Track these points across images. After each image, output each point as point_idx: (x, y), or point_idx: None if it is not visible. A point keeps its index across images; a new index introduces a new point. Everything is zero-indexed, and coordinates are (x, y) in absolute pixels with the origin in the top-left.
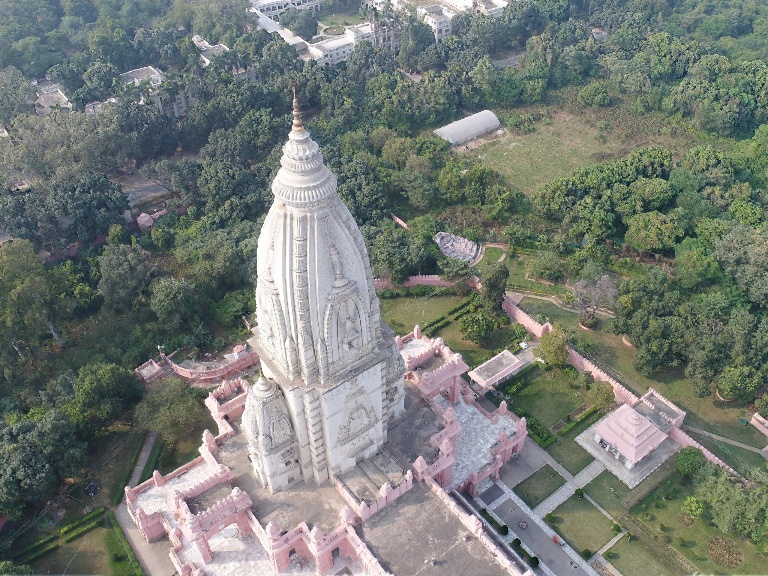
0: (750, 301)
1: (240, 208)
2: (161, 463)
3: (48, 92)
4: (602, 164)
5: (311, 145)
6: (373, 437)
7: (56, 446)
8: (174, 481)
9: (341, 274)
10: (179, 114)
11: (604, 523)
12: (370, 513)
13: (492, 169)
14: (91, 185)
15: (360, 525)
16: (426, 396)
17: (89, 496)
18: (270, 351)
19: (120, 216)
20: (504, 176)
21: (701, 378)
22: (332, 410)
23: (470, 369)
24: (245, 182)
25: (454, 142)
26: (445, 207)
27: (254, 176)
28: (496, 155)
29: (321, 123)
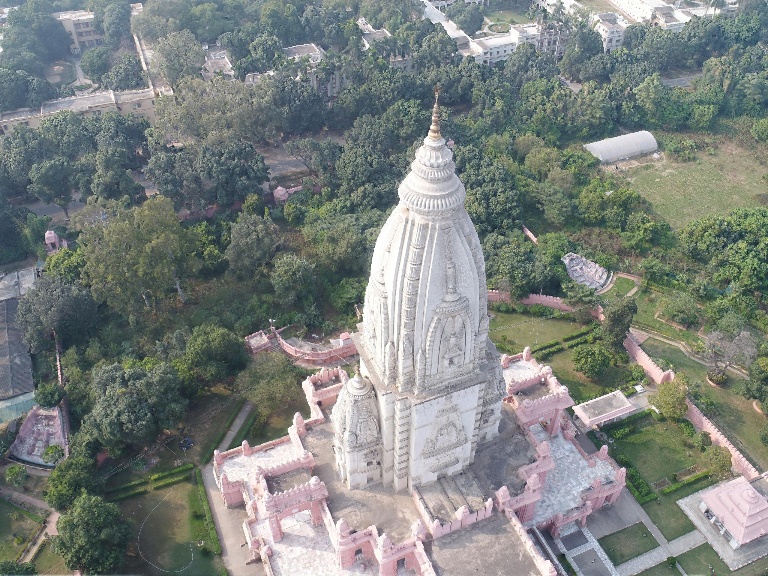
0: None
1: (372, 196)
2: (252, 433)
3: (216, 57)
4: (766, 207)
5: (445, 153)
6: (459, 456)
7: (160, 398)
8: (260, 454)
9: (453, 288)
10: (332, 94)
11: None
12: (442, 532)
13: (640, 194)
14: (237, 153)
15: (430, 542)
16: (523, 424)
17: (182, 450)
18: (370, 350)
19: (259, 186)
20: (652, 204)
21: None
22: (422, 422)
23: (576, 403)
24: (382, 171)
25: (604, 160)
26: (581, 227)
27: (392, 166)
28: (647, 180)
29: (468, 121)
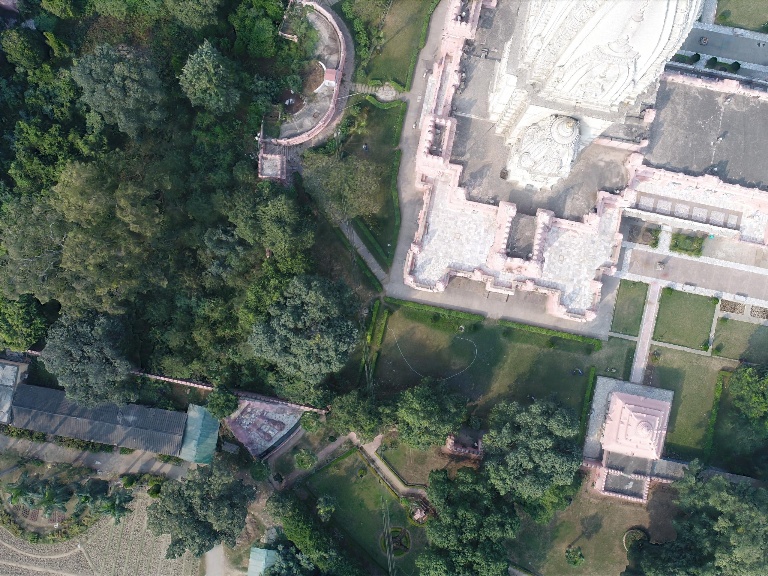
0: None
1: None
2: (378, 232)
3: None
4: None
5: None
6: None
7: (336, 305)
8: (427, 239)
9: None
10: None
11: None
12: None
13: None
14: None
15: None
16: None
17: None
18: (573, 99)
19: None
20: None
21: None
22: None
23: None
24: None
25: None
26: None
27: None
28: None
29: None
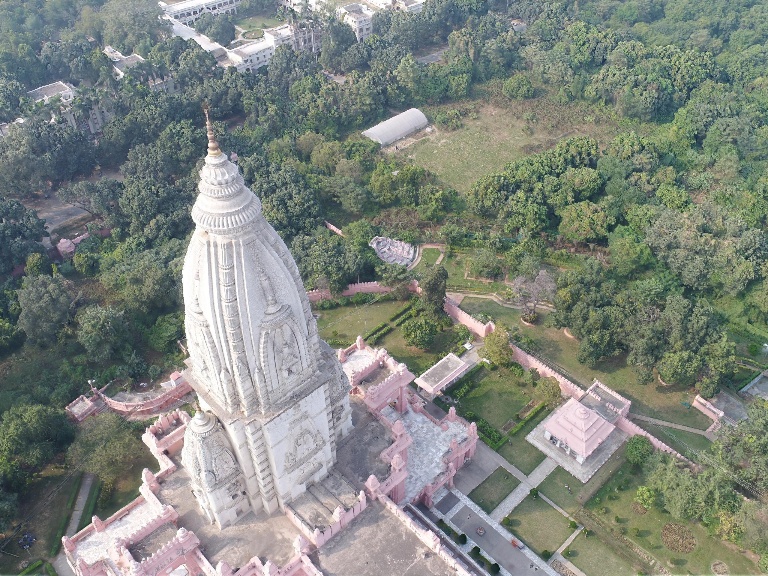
0: (683, 284)
1: (167, 226)
2: (100, 506)
3: None
4: (531, 157)
5: (230, 168)
6: (322, 460)
7: None
8: (115, 525)
9: (273, 300)
10: (95, 130)
11: (560, 521)
12: (325, 539)
13: (423, 168)
14: (3, 213)
15: (315, 553)
16: (373, 410)
17: (24, 549)
18: (205, 384)
19: (38, 243)
20: (436, 174)
21: (643, 366)
22: (276, 439)
23: (416, 376)
24: (170, 198)
25: (383, 143)
26: (379, 210)
27: (179, 191)
28: (426, 153)
29: (246, 131)
